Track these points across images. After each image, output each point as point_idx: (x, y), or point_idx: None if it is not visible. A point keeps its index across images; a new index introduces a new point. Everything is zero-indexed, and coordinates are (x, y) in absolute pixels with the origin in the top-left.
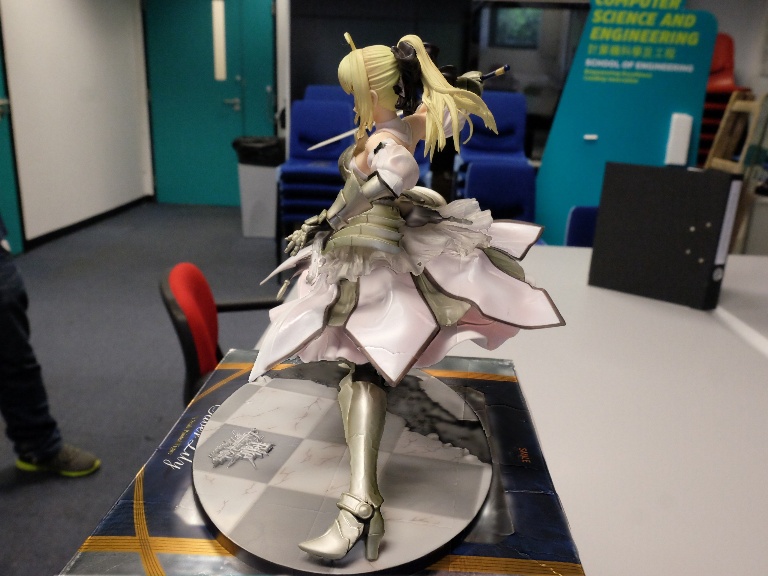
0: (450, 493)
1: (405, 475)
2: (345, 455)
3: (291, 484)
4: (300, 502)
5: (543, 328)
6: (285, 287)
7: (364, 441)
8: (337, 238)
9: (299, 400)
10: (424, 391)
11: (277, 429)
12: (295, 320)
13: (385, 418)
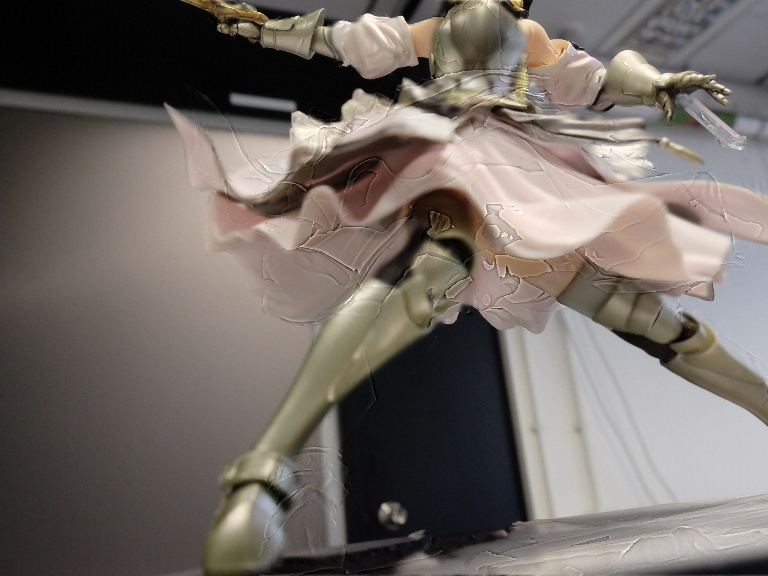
0: None
1: None
2: None
3: None
4: None
5: None
6: (701, 135)
7: None
8: None
9: None
10: (355, 572)
11: None
12: None
13: None
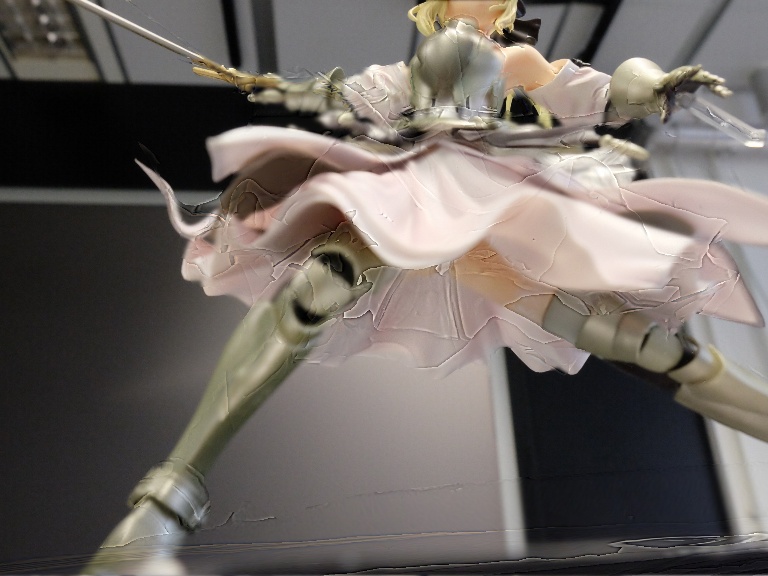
0: None
1: None
2: None
3: None
4: None
5: None
6: None
7: None
8: None
9: None
10: None
11: None
12: None
13: None
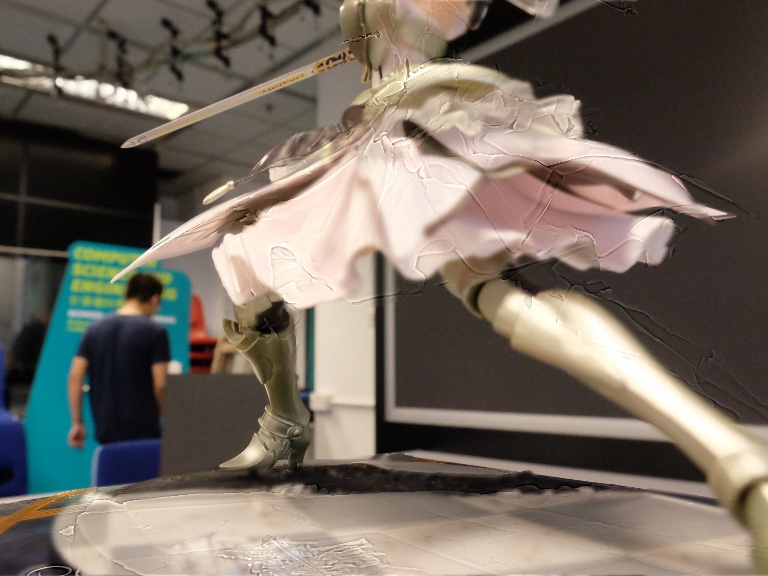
0: (716, 509)
1: (621, 515)
2: (493, 525)
3: (543, 566)
4: (632, 575)
5: (724, 222)
6: None
7: (729, 362)
8: (466, 64)
9: (238, 509)
10: (395, 469)
11: (300, 535)
12: (489, 164)
13: (416, 496)
